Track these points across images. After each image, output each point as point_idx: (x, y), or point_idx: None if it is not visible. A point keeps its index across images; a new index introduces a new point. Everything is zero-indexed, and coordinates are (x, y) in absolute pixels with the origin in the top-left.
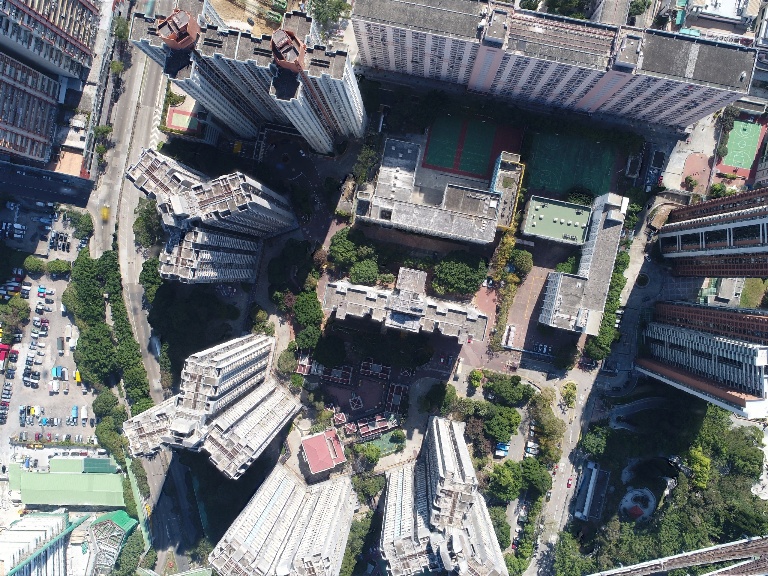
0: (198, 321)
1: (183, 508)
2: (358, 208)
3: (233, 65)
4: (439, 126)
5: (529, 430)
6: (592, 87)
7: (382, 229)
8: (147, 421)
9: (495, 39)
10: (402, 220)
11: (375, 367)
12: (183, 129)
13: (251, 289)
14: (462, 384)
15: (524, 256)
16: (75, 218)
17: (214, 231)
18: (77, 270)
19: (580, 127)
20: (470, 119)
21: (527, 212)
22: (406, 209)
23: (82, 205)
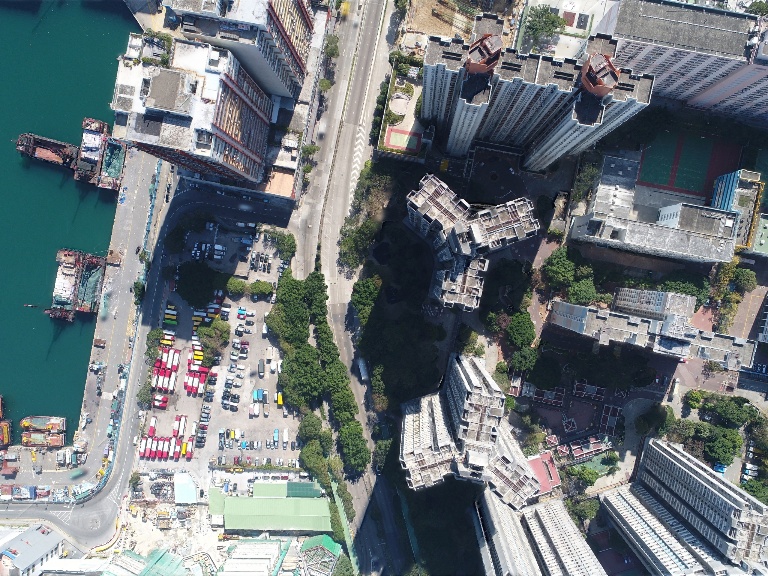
0: (410, 343)
1: (387, 532)
2: (588, 228)
3: (523, 88)
4: (654, 142)
5: (746, 451)
6: None
7: (594, 248)
8: (429, 453)
9: None
10: (636, 240)
11: (590, 388)
12: (402, 148)
13: (460, 310)
14: (676, 405)
15: (749, 275)
16: (280, 239)
17: None
18: (285, 292)
19: None
20: (694, 135)
21: (755, 230)
22: (640, 229)
23: (283, 225)
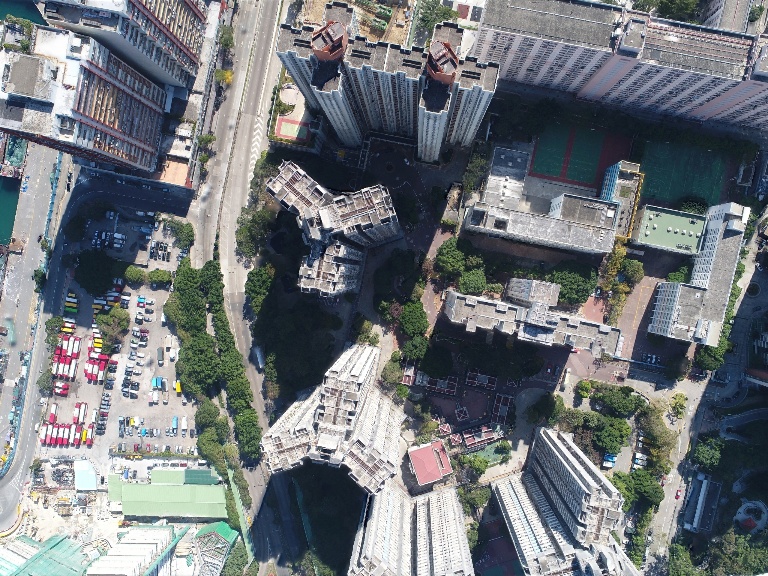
0: (303, 331)
1: (284, 519)
2: (472, 218)
3: (377, 76)
4: (546, 134)
5: (637, 441)
6: (719, 96)
7: (488, 238)
8: (286, 436)
9: (632, 48)
10: (518, 230)
11: (481, 378)
12: (292, 138)
13: (355, 299)
14: (568, 395)
15: (636, 266)
16: (177, 228)
17: (344, 243)
18: (180, 280)
19: (693, 135)
20: (582, 127)
21: (640, 221)
22: (522, 219)
23: (182, 214)
